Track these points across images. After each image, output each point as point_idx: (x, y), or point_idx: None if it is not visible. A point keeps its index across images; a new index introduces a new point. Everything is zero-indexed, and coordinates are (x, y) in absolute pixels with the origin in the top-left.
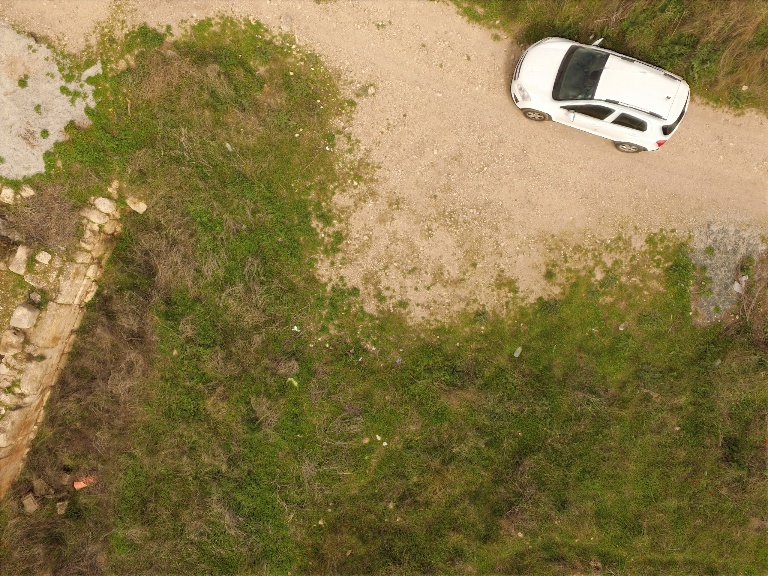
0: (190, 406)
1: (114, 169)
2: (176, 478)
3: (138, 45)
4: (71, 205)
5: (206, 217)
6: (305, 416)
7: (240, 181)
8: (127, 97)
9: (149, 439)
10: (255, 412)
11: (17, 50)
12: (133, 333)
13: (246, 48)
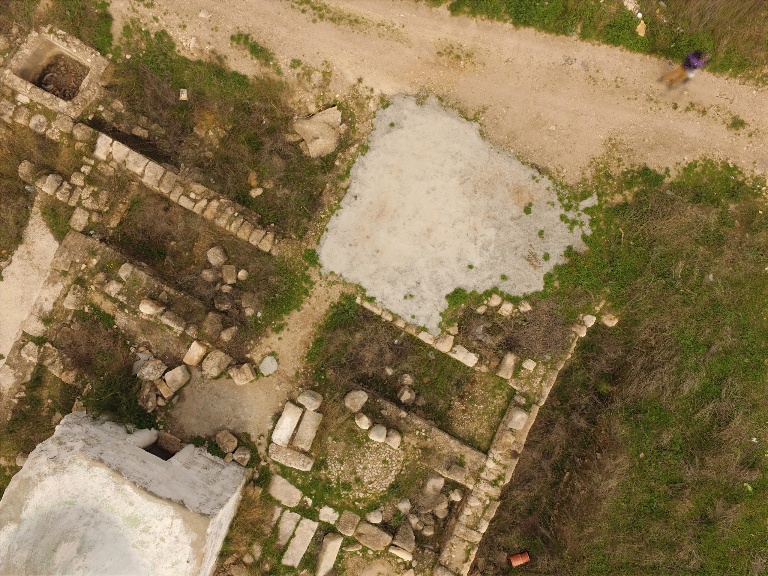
0: (653, 503)
1: (605, 291)
2: (635, 567)
3: (640, 184)
4: (563, 320)
5: (690, 339)
6: (758, 518)
7: (722, 309)
8: (620, 227)
9: (612, 531)
10: (715, 512)
11: (523, 180)
12: (589, 432)
13: (720, 187)
